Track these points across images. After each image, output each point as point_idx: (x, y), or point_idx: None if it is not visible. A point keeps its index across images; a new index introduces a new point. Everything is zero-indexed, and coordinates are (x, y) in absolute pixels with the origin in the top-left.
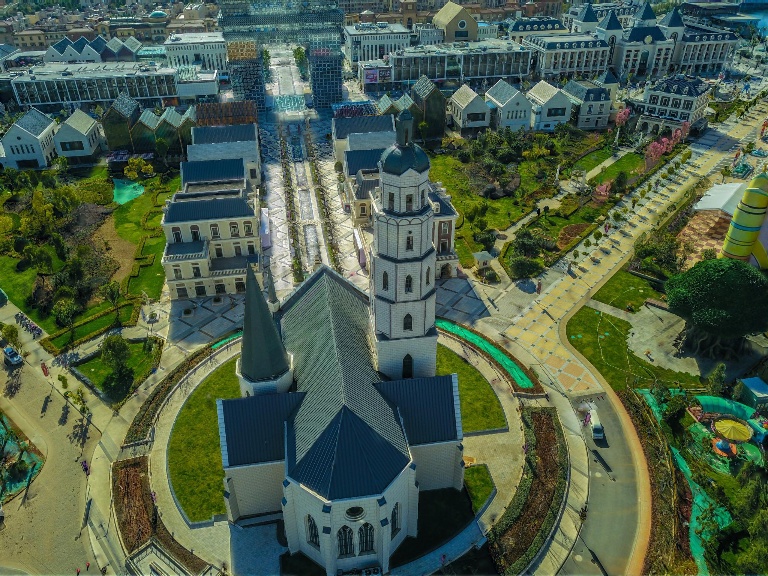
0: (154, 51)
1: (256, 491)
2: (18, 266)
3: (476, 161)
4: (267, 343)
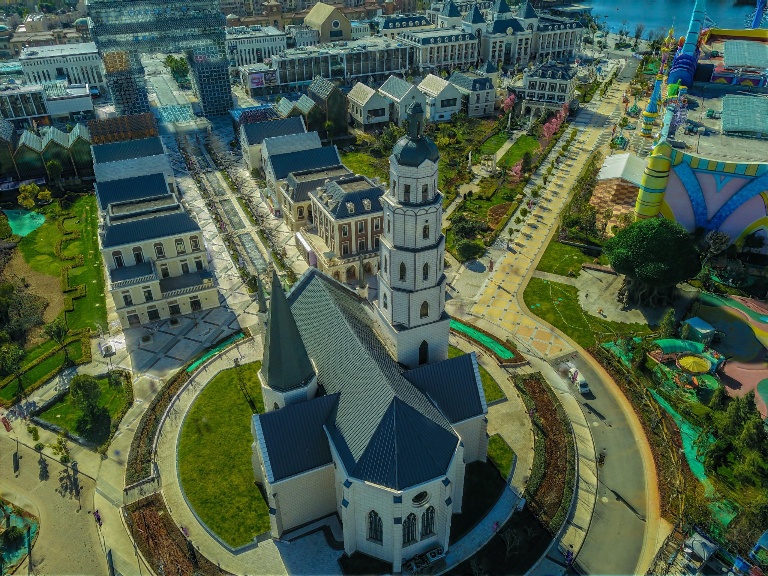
0: (7, 68)
1: (300, 502)
2: None
3: (388, 155)
4: (295, 350)
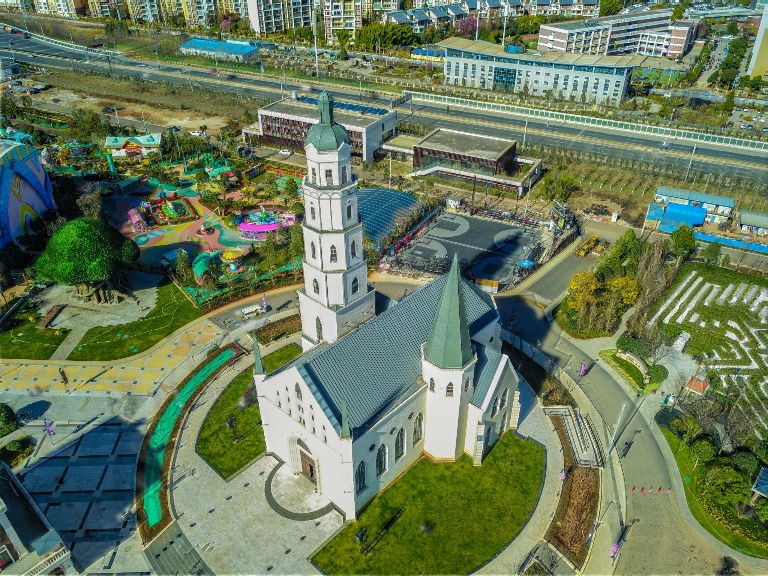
0: None
1: None
2: None
3: None
4: None
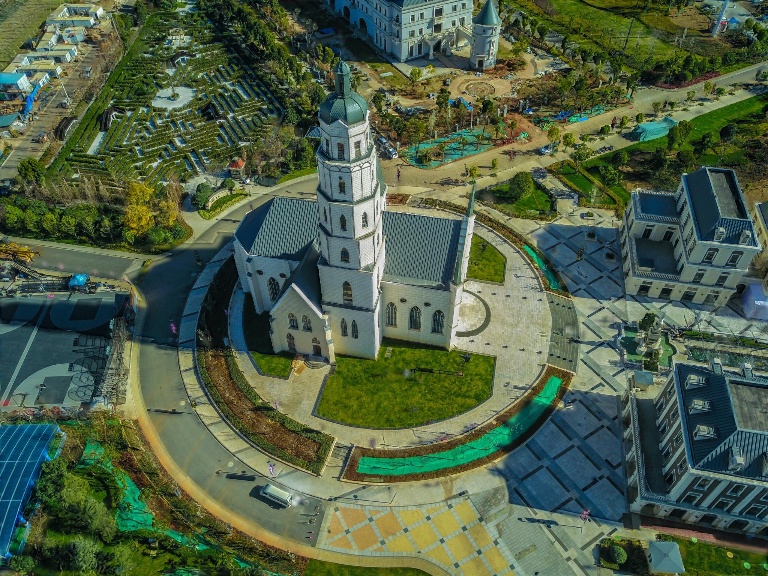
0: None
1: None
2: None
3: None
4: None
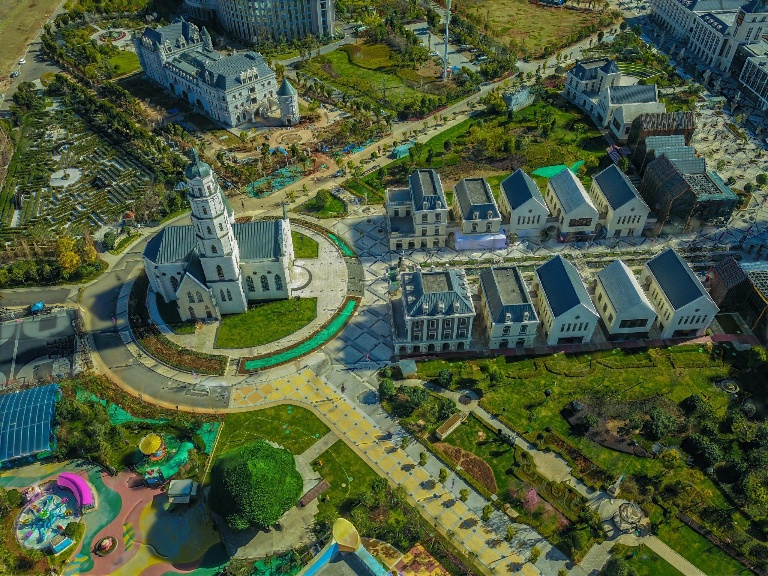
0: None
1: None
2: None
3: (691, 417)
4: None
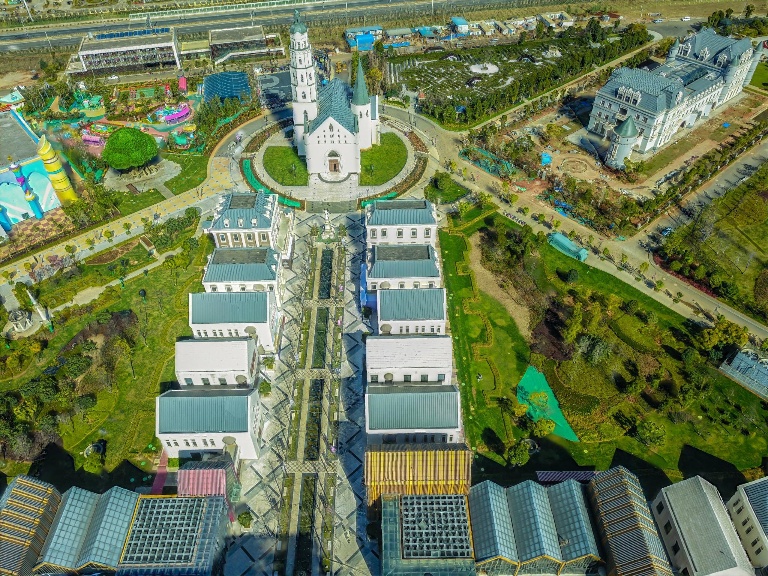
0: None
1: None
2: (567, 273)
3: None
4: None
